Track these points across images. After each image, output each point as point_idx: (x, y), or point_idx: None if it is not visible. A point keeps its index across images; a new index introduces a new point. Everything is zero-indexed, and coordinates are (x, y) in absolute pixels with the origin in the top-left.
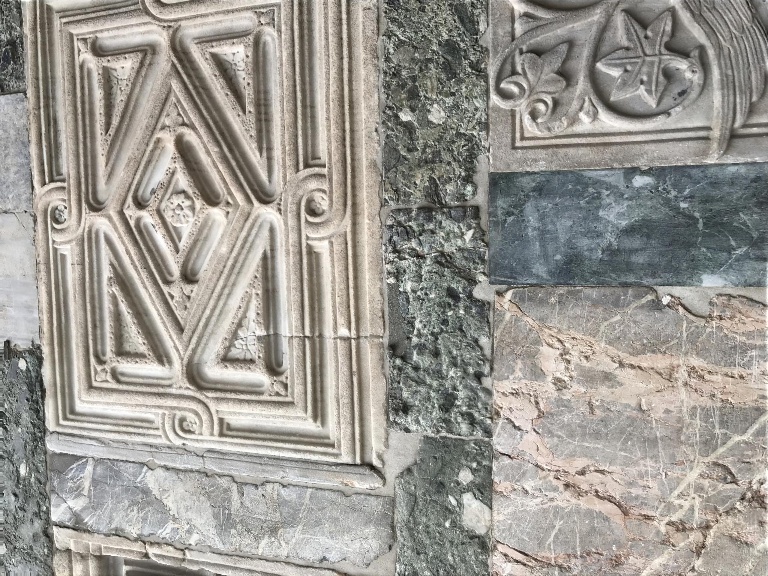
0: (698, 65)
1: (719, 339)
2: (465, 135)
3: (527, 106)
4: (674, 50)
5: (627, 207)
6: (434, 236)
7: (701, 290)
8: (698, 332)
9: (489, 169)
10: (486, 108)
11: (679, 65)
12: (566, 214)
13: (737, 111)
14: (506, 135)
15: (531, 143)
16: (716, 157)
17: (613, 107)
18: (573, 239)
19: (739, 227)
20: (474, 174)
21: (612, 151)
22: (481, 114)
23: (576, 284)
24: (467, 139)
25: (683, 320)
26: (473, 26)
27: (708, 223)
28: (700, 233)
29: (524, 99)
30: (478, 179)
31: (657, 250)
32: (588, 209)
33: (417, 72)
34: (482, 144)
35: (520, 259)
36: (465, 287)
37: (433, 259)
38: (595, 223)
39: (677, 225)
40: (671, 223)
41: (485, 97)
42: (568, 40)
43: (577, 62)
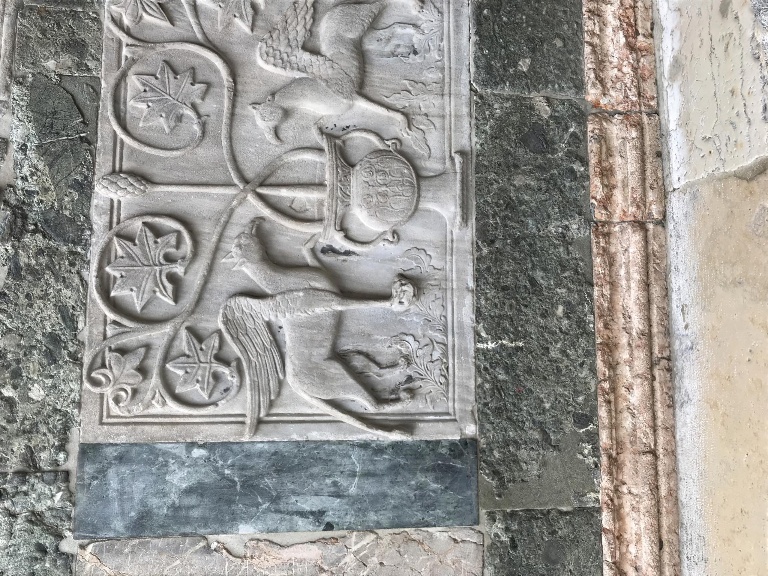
0: (236, 372)
1: (250, 575)
2: (60, 411)
3: (111, 393)
4: (221, 359)
5: (187, 473)
6: (26, 498)
7: (238, 537)
8: (236, 570)
9: (79, 440)
10: (80, 390)
11: (224, 370)
12: (140, 479)
13: (261, 406)
14: (95, 413)
15: (115, 420)
16: (248, 438)
17: (177, 397)
18: (145, 499)
19: (264, 488)
20: (66, 443)
21: (177, 429)
22: (75, 395)
23: (146, 536)
24: (62, 414)
25: (225, 561)
26: (72, 324)
27: (244, 485)
28: (238, 493)
29: (109, 387)
30: (70, 448)
31: (208, 507)
32: (158, 474)
33: (21, 356)
34: (75, 419)
35: (101, 517)
36: (52, 542)
37: (23, 518)
38: (162, 486)
39: (222, 487)
40: (218, 485)
41: (79, 381)
42: (146, 345)
43: (152, 362)
